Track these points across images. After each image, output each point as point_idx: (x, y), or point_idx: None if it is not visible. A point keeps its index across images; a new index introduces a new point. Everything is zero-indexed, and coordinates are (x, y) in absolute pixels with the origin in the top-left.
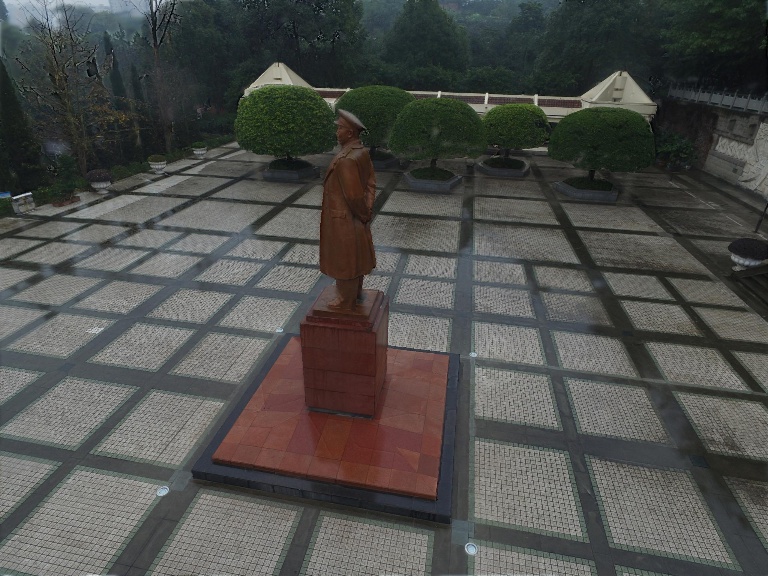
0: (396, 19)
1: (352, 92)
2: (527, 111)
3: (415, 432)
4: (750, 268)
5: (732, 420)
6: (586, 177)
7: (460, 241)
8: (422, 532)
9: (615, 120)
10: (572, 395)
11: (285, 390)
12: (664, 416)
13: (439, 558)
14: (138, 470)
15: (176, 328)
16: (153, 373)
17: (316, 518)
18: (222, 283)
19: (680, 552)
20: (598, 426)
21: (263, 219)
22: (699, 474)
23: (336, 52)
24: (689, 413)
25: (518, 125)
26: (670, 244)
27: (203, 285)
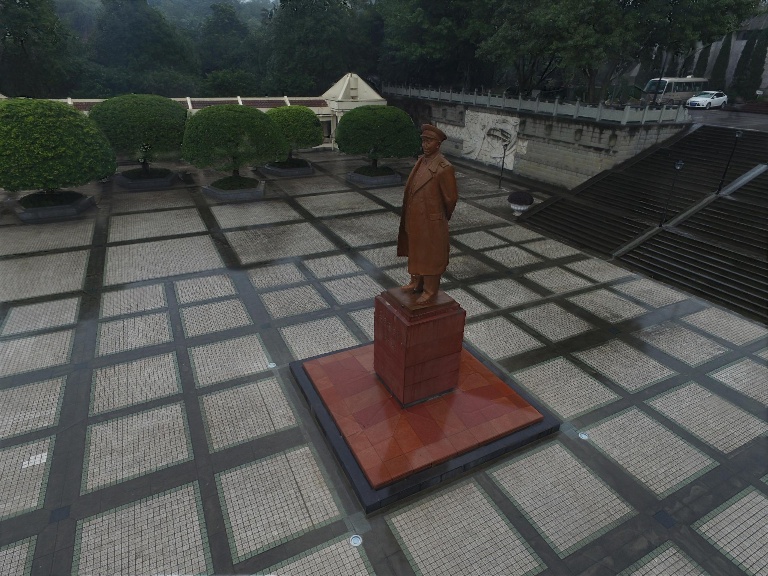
0: (97, 16)
1: (108, 103)
2: (303, 112)
3: (487, 385)
4: (526, 211)
5: (603, 303)
6: (369, 166)
7: (329, 239)
8: (552, 444)
9: (390, 115)
10: (526, 322)
11: (362, 405)
12: (577, 314)
13: (577, 452)
14: (309, 542)
15: (153, 410)
16: (192, 461)
17: (489, 478)
18: (141, 347)
19: (655, 379)
20: (558, 334)
21: (94, 267)
22: (621, 337)
23: (27, 54)
24: (584, 307)
25: (301, 126)
26: (466, 206)
27: (119, 357)
